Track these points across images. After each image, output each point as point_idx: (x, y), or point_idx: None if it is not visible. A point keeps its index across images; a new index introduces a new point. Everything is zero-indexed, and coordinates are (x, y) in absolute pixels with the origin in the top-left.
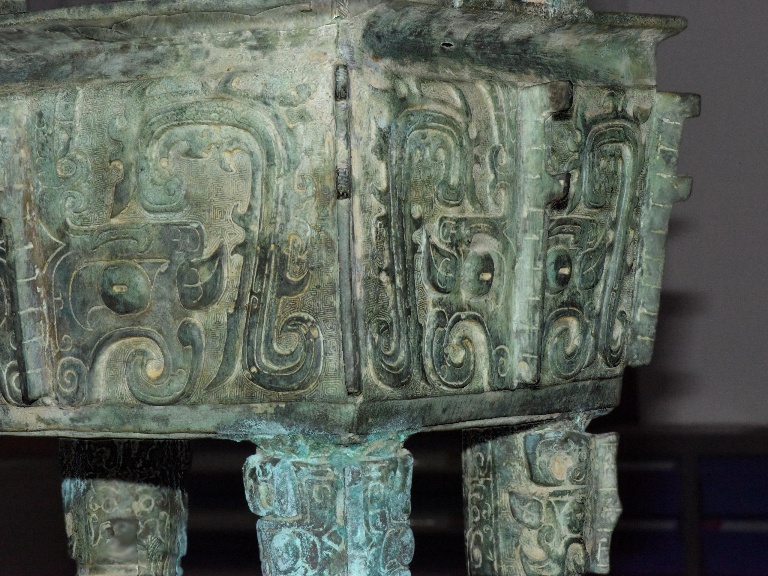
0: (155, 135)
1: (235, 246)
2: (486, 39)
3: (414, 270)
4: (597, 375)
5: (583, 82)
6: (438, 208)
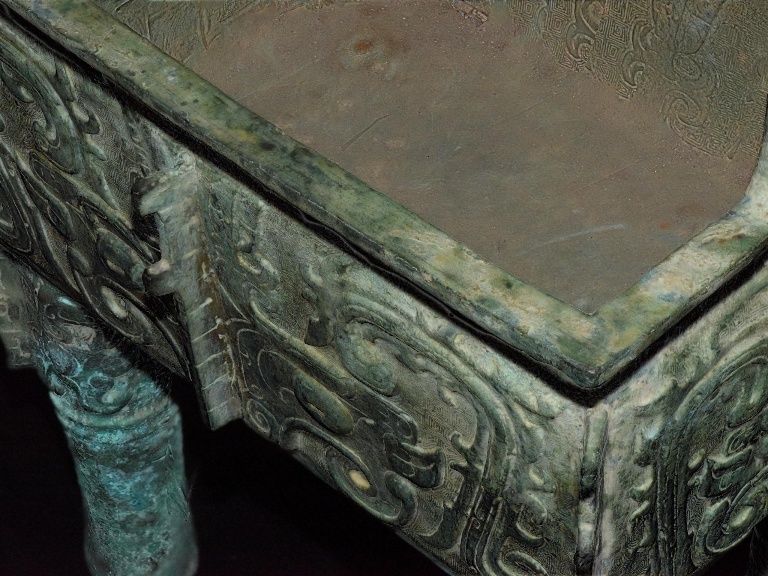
0: (357, 319)
1: (455, 464)
2: None
3: (687, 500)
4: None
5: None
6: (729, 430)
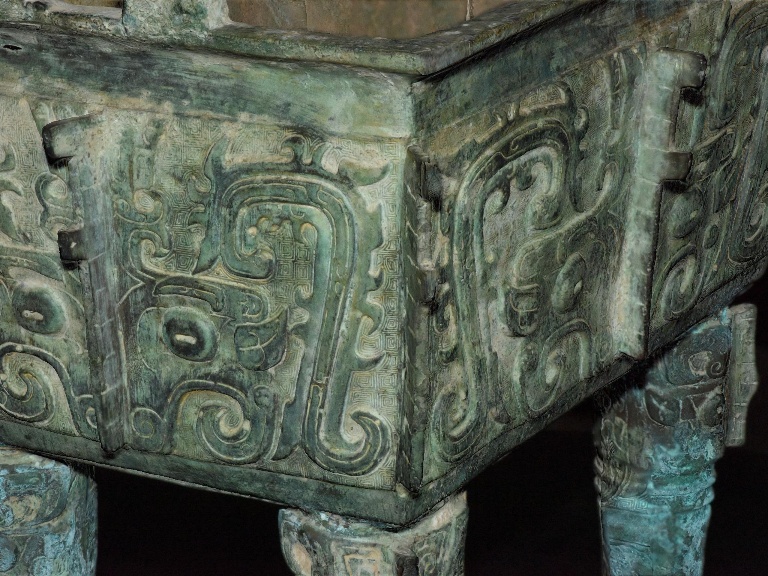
0: None
1: None
2: None
3: None
4: (317, 475)
5: (252, 116)
6: None
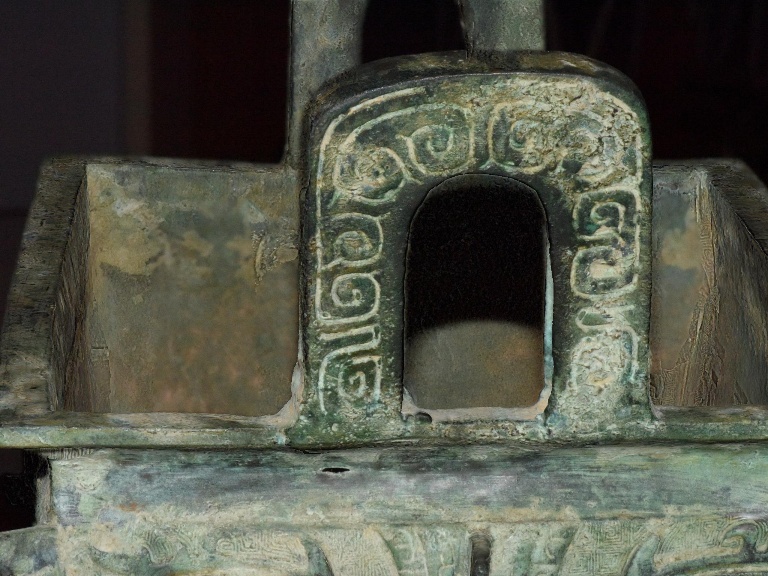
0: None
1: None
2: (429, 459)
3: None
4: None
5: (681, 508)
6: None
